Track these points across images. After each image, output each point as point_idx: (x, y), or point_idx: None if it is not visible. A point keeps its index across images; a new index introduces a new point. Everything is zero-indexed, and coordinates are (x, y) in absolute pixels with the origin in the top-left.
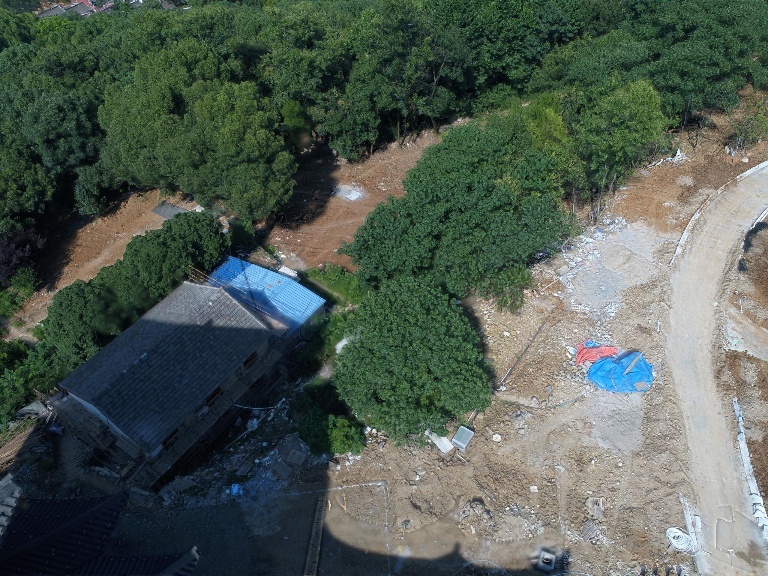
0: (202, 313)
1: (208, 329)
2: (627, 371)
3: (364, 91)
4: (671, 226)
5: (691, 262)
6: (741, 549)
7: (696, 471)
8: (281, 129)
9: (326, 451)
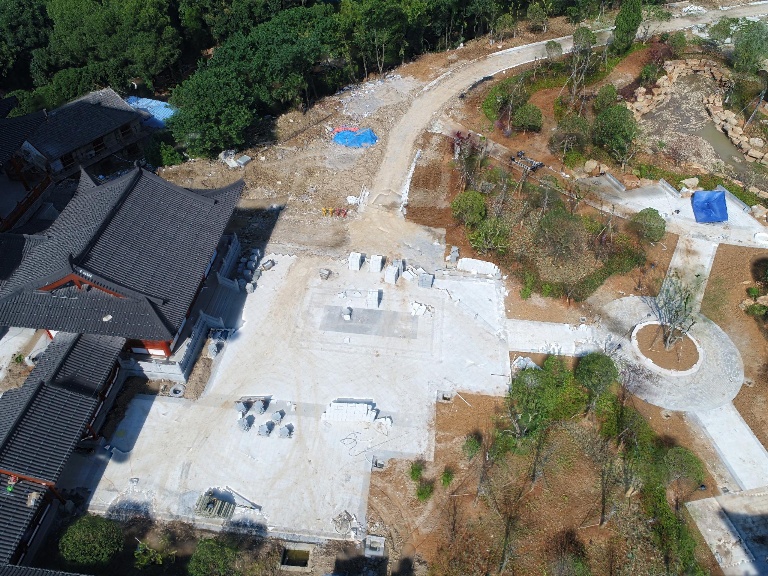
0: (95, 98)
1: (98, 107)
2: (356, 135)
3: (244, 3)
4: (430, 79)
5: (431, 94)
6: (386, 204)
7: (379, 177)
8: (186, 32)
9: (160, 165)
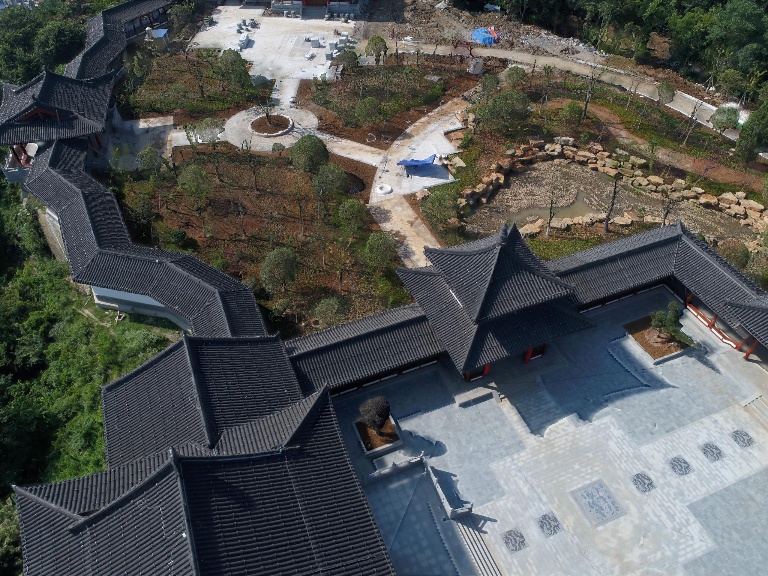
0: None
1: None
2: None
3: None
4: None
5: None
6: None
7: None
8: None
9: None
